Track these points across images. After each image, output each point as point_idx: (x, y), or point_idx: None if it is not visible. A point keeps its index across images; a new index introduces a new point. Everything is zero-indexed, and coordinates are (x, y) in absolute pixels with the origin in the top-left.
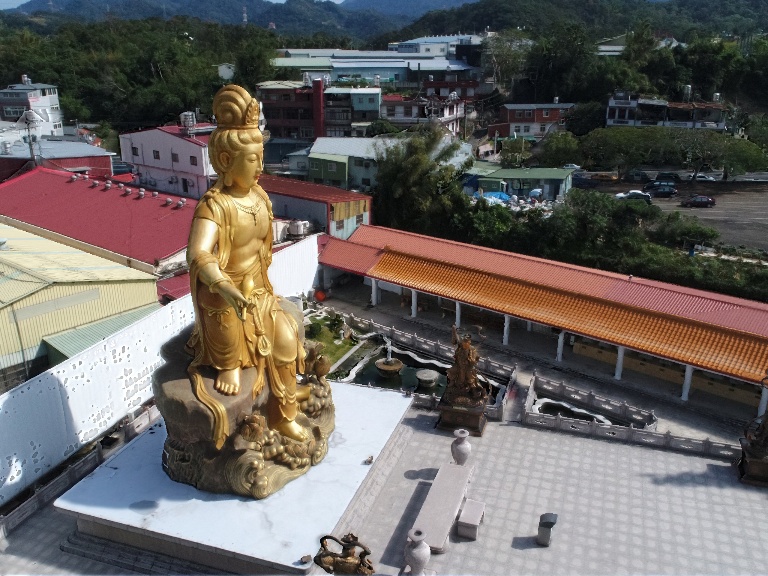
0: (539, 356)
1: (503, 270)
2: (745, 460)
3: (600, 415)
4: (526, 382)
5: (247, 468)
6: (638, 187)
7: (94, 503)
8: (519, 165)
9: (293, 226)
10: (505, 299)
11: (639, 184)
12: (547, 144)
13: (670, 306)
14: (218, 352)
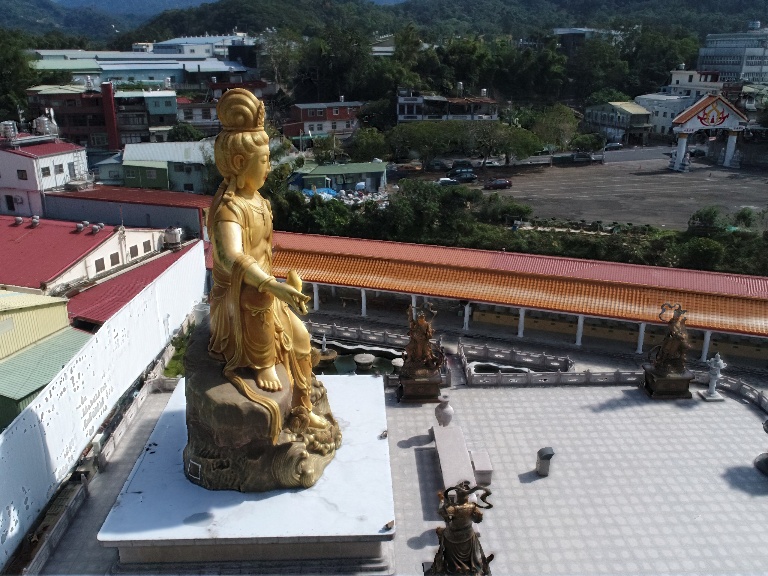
0: (448, 328)
1: (391, 256)
2: (651, 381)
3: (525, 368)
4: (450, 351)
5: (297, 459)
6: (441, 175)
7: (143, 528)
8: (326, 162)
9: (170, 234)
10: (411, 281)
11: (440, 173)
12: (357, 140)
13: (545, 270)
14: (257, 352)
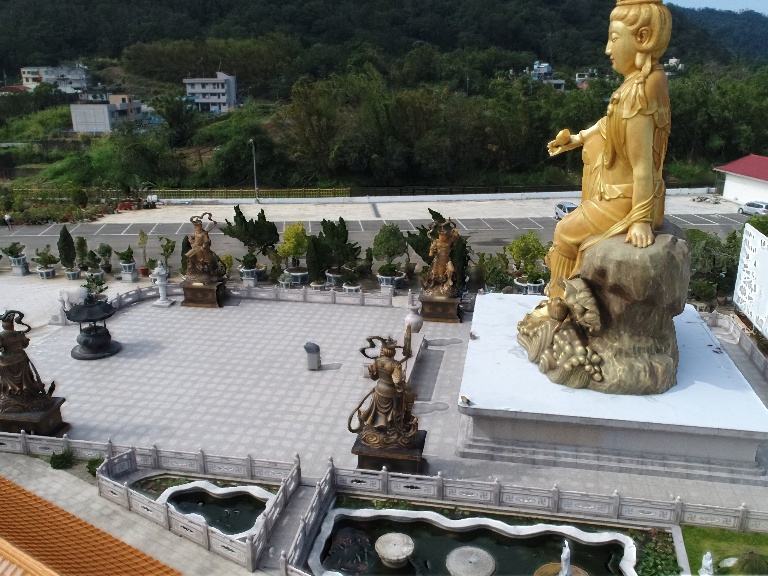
0: None
1: None
2: None
3: None
4: None
5: None
6: None
7: None
8: None
9: None
10: None
11: None
12: None
13: None
14: None
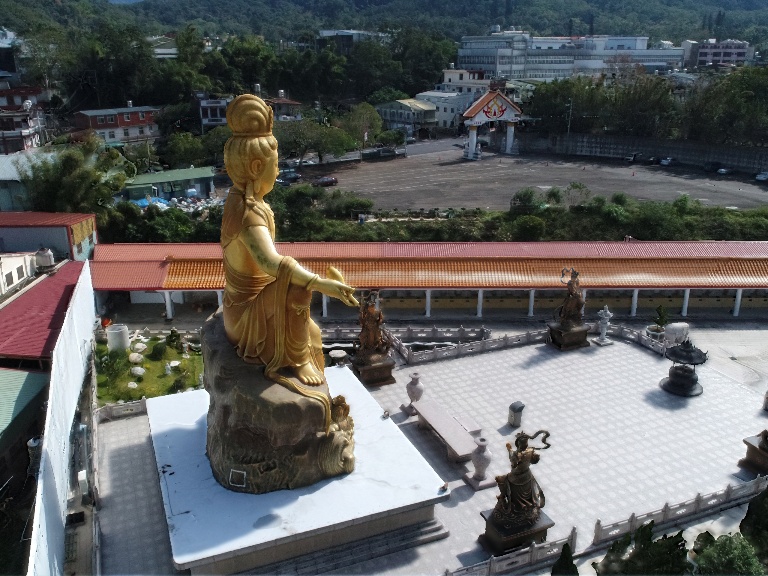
0: None
1: None
2: (558, 336)
3: (448, 342)
4: None
5: (342, 447)
6: None
7: (217, 542)
8: None
9: (44, 257)
10: None
11: None
12: (173, 146)
13: (433, 254)
14: (297, 350)
